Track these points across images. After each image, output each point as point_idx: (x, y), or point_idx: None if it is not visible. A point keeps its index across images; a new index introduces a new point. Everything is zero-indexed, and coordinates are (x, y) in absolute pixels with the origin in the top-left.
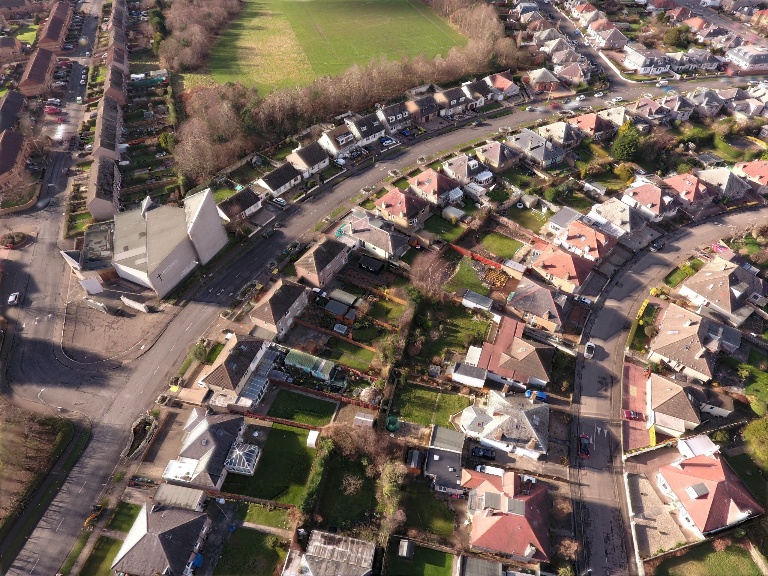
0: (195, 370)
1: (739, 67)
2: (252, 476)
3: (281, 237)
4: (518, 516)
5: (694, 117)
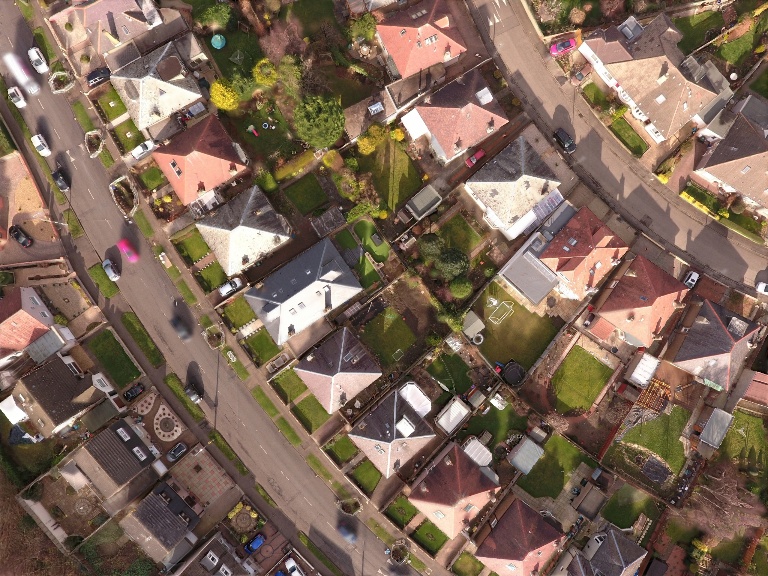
0: None
1: None
2: None
3: None
4: None
5: None
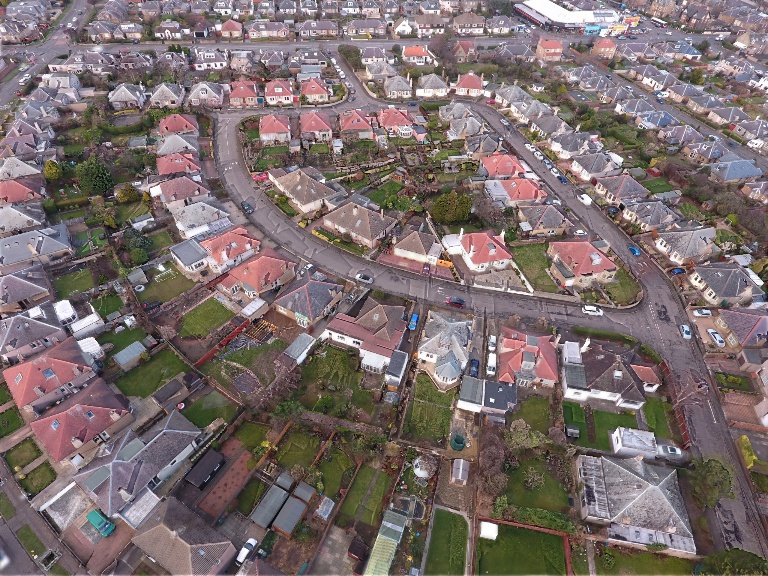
0: None
1: None
2: None
3: None
4: (538, 341)
5: (56, 128)
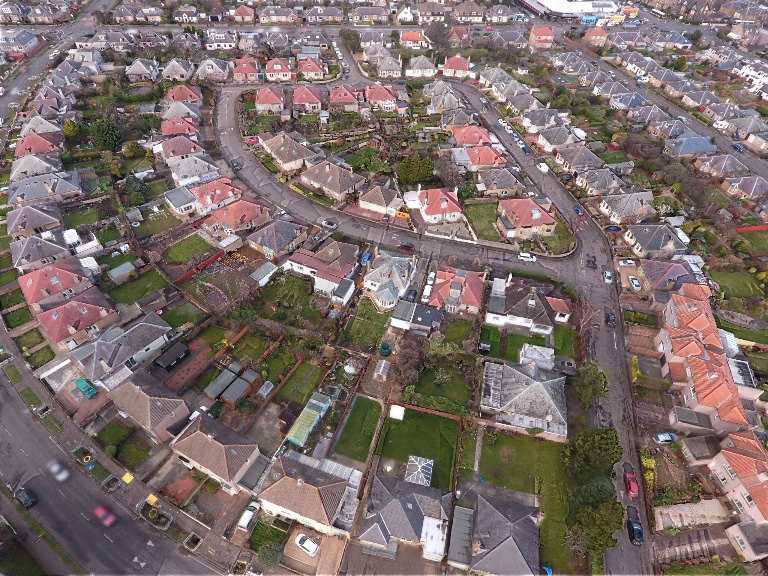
0: (289, 567)
1: (17, 52)
2: (432, 468)
3: (46, 478)
4: (467, 274)
5: (77, 96)
